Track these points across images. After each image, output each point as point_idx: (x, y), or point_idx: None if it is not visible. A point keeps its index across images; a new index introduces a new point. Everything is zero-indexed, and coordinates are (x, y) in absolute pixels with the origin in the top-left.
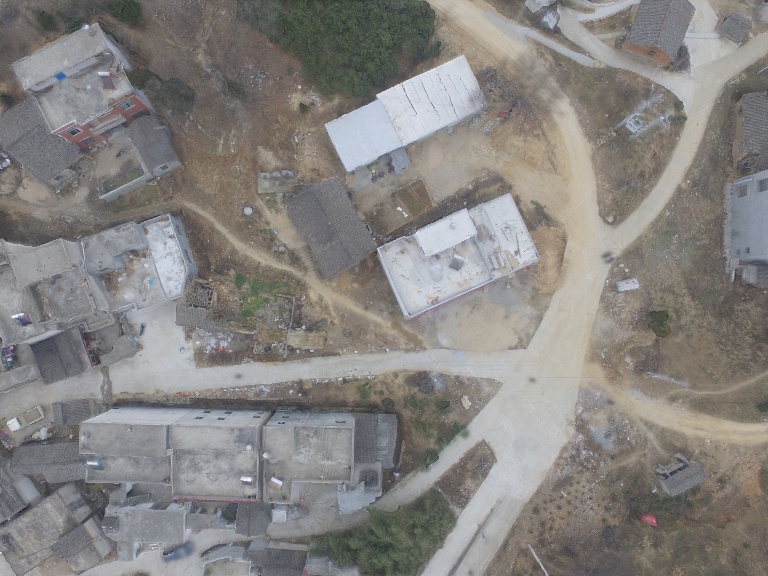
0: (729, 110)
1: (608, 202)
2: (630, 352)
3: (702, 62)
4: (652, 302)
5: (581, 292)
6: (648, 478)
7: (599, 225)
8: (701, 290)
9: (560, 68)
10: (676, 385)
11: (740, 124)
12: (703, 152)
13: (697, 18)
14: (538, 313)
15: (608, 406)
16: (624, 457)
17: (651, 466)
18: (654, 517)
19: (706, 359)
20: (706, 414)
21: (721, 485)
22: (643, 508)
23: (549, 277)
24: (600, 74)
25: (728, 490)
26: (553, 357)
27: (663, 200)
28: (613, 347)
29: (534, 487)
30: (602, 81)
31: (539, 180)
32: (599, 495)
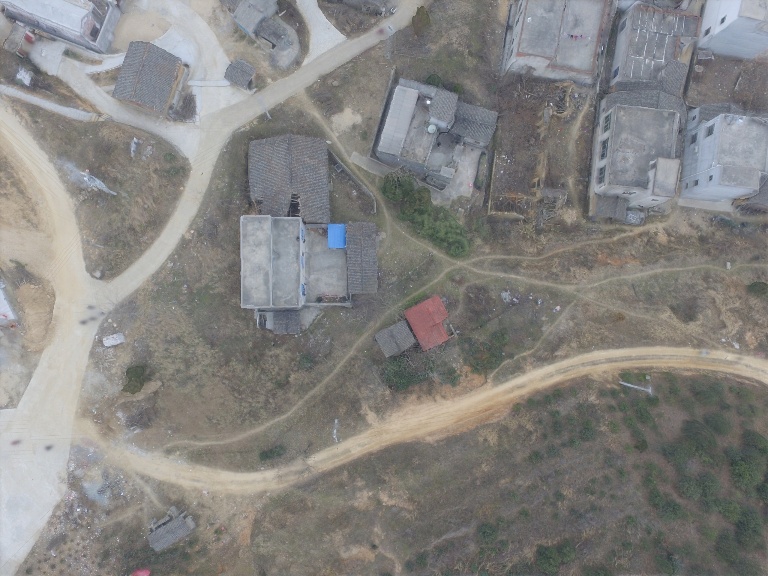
0: (245, 157)
1: (95, 257)
2: (121, 407)
3: (209, 110)
4: (153, 354)
5: (70, 349)
6: (145, 532)
7: (87, 281)
8: (225, 338)
9: (36, 125)
10: (174, 437)
11: (248, 171)
12: (208, 201)
13: (210, 66)
14: (28, 372)
15: (102, 462)
16: (119, 512)
17: (148, 520)
18: (149, 572)
19: (217, 408)
20: (202, 466)
21: (217, 536)
22: (132, 564)
23: (33, 336)
24: (86, 129)
25: (226, 541)
26: (44, 415)
27: (166, 251)
28: (104, 403)
29: (28, 547)
30: (86, 136)
31: (18, 239)
32: (93, 552)
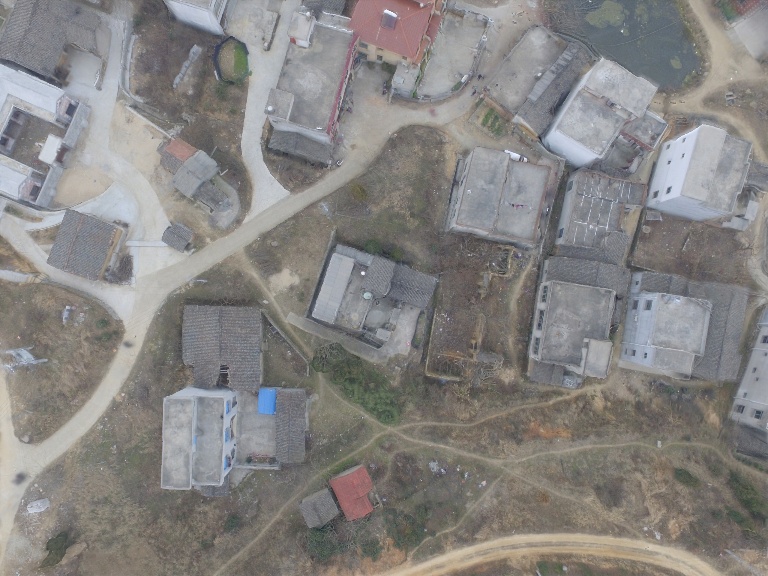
0: (181, 317)
1: (24, 422)
2: (44, 571)
3: (146, 272)
4: (79, 516)
5: None
6: None
7: (16, 445)
8: (154, 494)
9: None
10: None
11: (182, 335)
12: (140, 364)
13: (149, 225)
14: None
15: None
16: None
17: None
18: None
19: (141, 569)
20: None
21: None
22: None
23: None
24: (20, 293)
25: None
26: None
27: (96, 413)
28: (28, 566)
29: None
30: (20, 301)
31: None
32: None
